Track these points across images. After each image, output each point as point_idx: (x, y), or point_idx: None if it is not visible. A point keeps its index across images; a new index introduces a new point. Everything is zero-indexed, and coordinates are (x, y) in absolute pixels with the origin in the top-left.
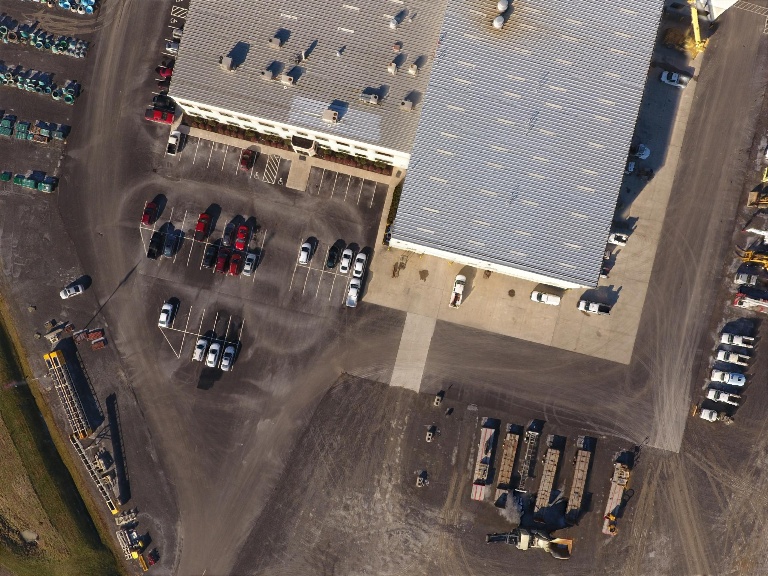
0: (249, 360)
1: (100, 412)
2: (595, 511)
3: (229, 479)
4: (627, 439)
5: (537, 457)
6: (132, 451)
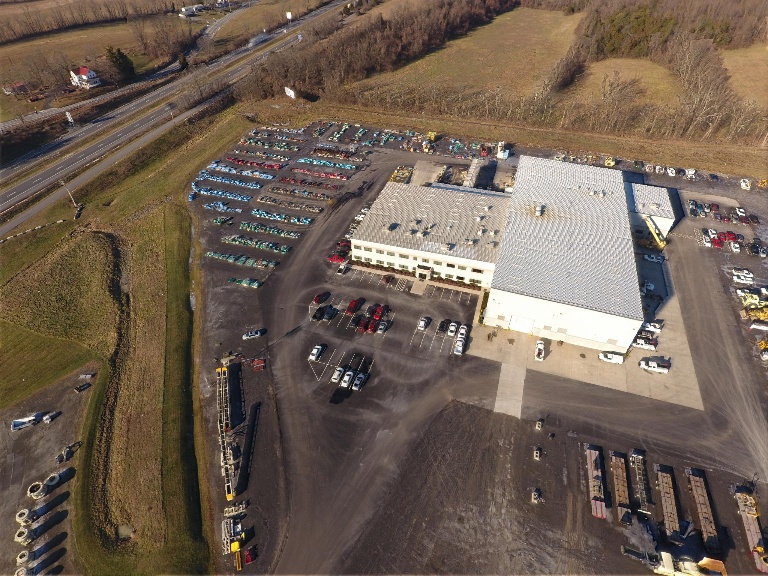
0: (375, 385)
1: (243, 415)
2: (738, 549)
3: (345, 479)
4: (735, 473)
5: (650, 484)
6: (261, 447)
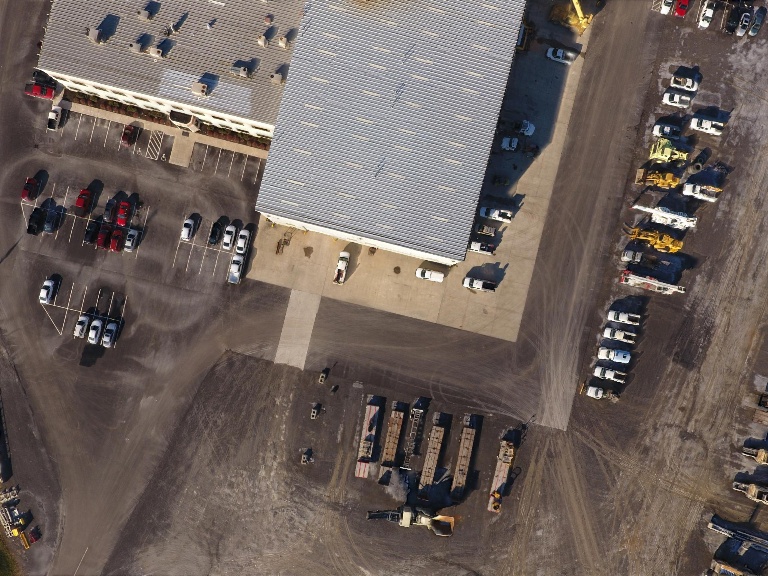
0: (132, 337)
1: None
2: (482, 489)
3: (112, 456)
4: (514, 417)
5: (423, 435)
6: (14, 428)
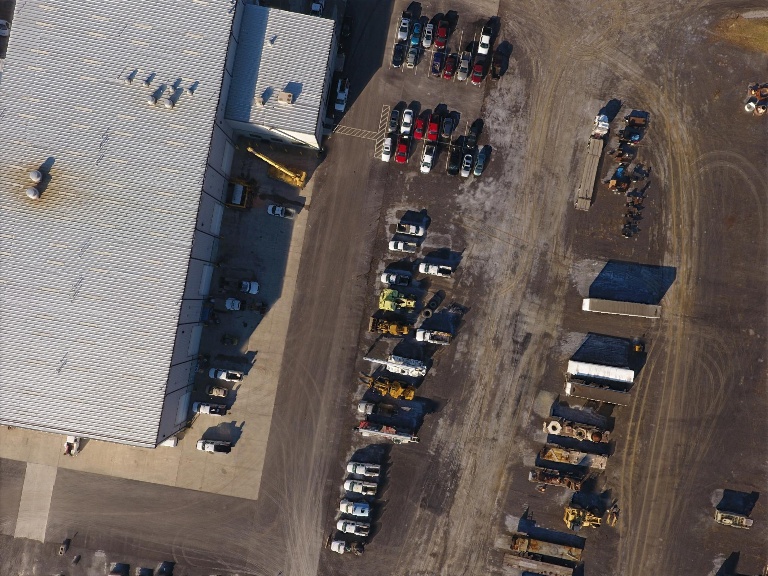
0: None
1: None
2: None
3: None
4: (260, 575)
5: None
6: None
